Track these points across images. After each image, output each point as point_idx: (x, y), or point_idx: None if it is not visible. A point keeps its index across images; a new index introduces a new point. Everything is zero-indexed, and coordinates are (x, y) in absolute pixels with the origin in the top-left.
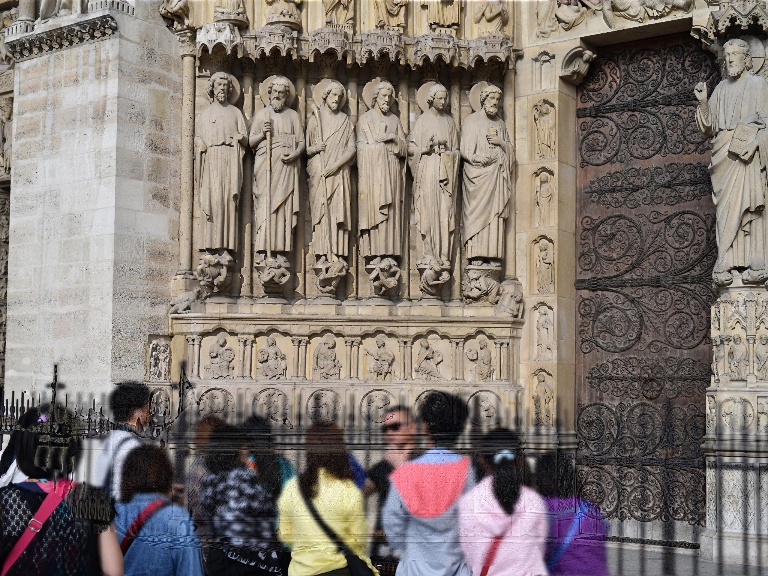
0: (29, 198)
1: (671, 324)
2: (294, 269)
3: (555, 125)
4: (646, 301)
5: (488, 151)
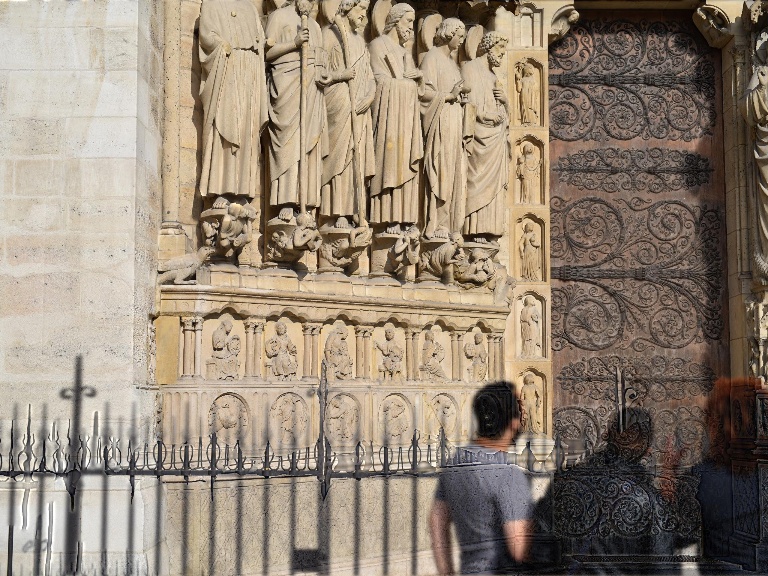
0: None
1: (658, 321)
2: None
3: (544, 89)
4: (628, 295)
5: (496, 108)
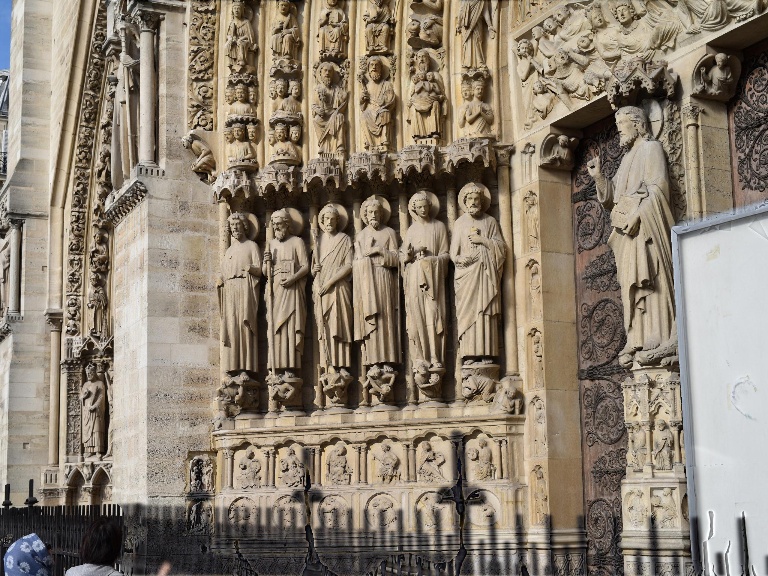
0: (120, 340)
1: None
2: (313, 383)
3: (537, 215)
4: None
5: (470, 251)
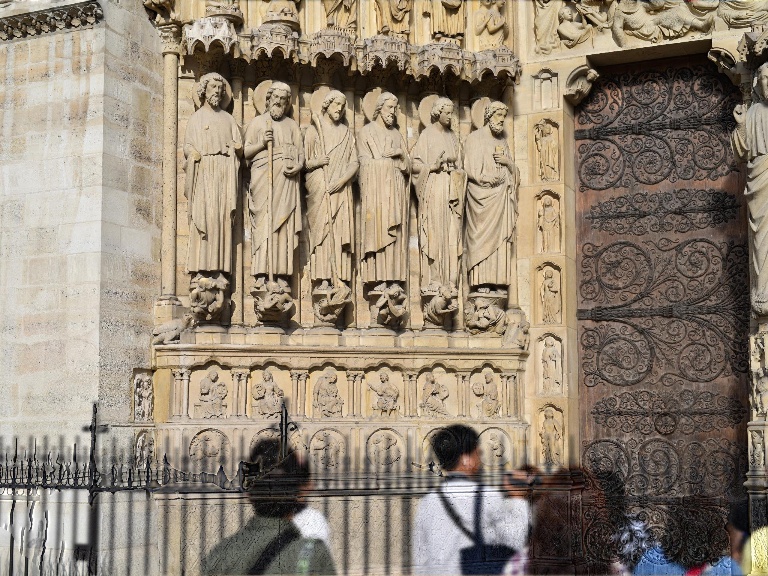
0: None
1: (686, 356)
2: None
3: (560, 146)
4: (657, 332)
5: (495, 171)
